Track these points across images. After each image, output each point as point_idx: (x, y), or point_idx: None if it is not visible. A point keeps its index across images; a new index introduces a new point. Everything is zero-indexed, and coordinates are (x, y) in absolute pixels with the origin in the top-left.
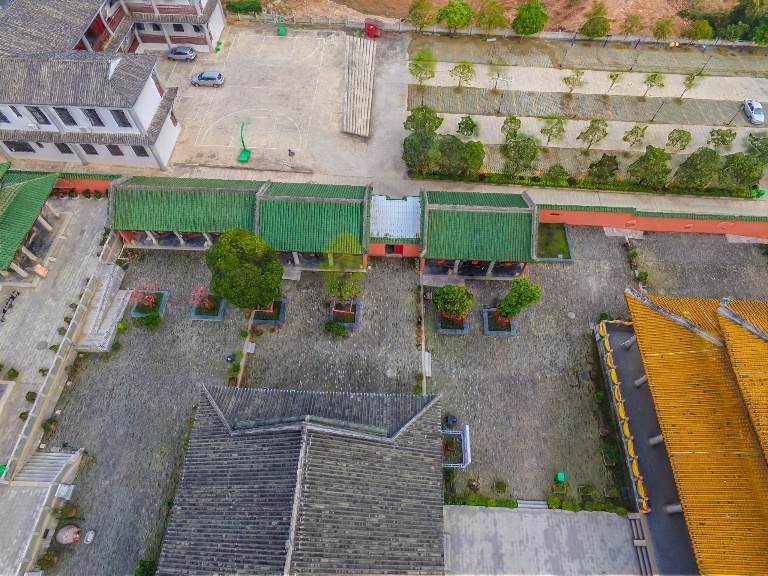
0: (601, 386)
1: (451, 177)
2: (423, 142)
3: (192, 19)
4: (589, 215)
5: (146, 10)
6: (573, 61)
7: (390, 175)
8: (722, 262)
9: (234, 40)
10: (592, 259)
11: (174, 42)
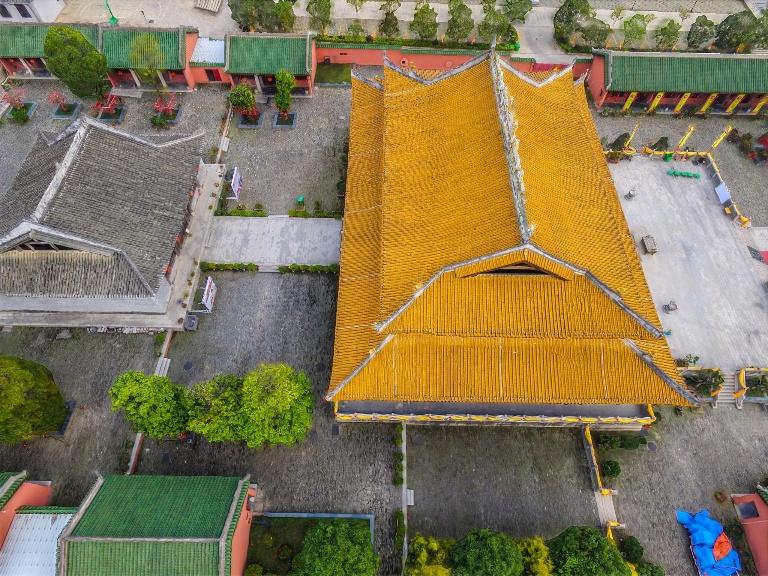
0: None
1: None
2: None
3: None
4: (369, 54)
5: None
6: None
7: None
8: None
9: None
10: None
11: None
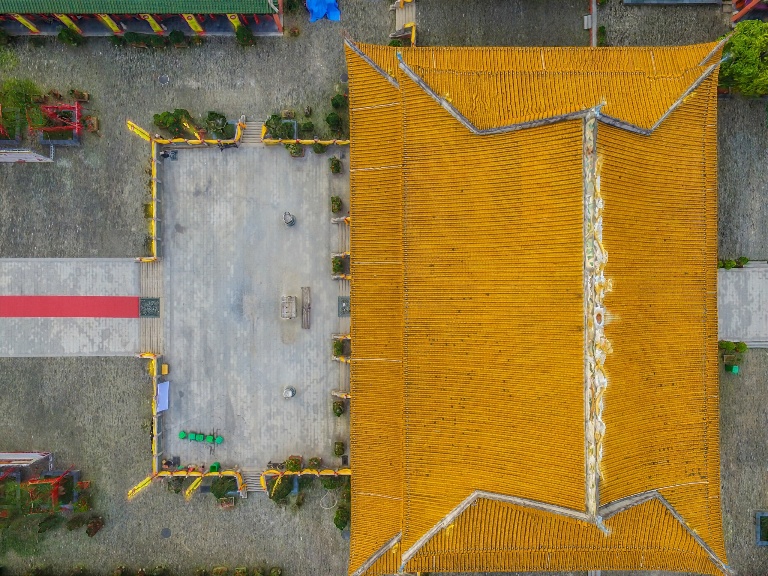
0: None
1: None
2: None
3: None
4: None
5: None
6: None
7: None
8: None
9: None
10: None
11: None
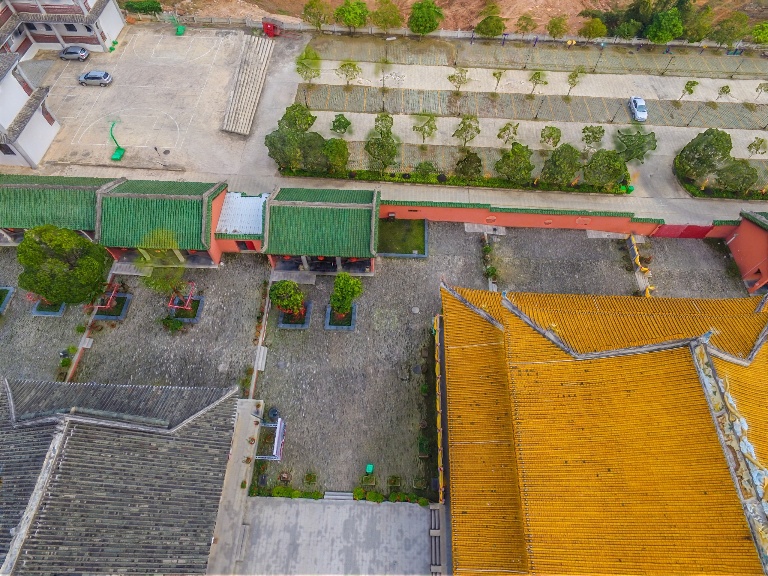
0: (431, 379)
1: (321, 174)
2: (281, 139)
3: (79, 19)
4: (447, 211)
5: (33, 10)
6: (469, 59)
7: (262, 173)
8: (577, 257)
9: (131, 40)
10: (447, 255)
11: (67, 42)
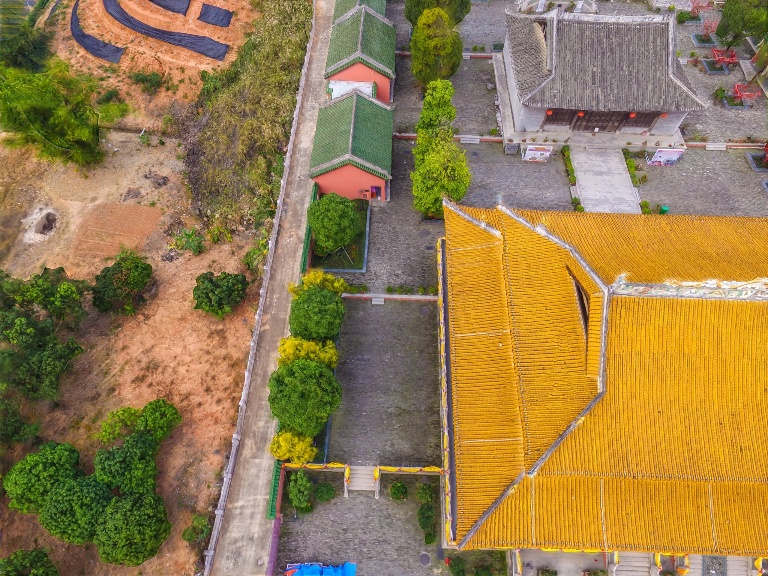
0: None
1: None
2: None
3: None
4: None
5: None
6: None
7: None
8: None
9: None
10: None
11: None
